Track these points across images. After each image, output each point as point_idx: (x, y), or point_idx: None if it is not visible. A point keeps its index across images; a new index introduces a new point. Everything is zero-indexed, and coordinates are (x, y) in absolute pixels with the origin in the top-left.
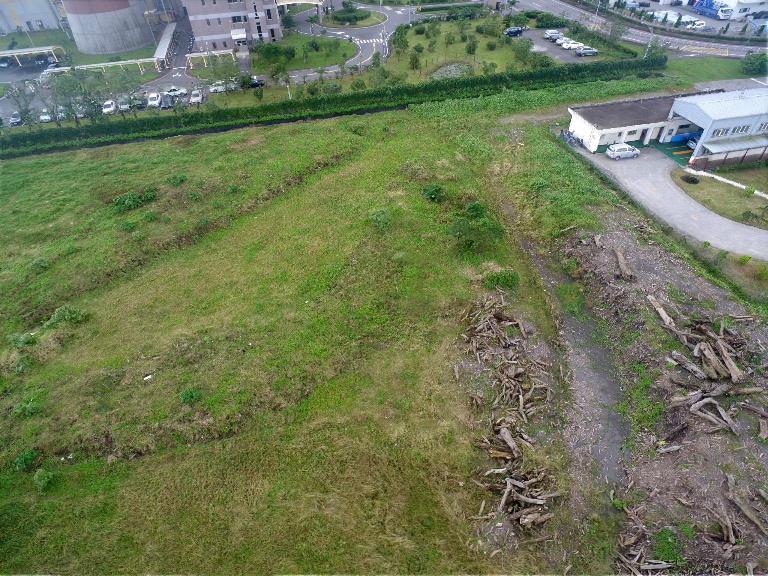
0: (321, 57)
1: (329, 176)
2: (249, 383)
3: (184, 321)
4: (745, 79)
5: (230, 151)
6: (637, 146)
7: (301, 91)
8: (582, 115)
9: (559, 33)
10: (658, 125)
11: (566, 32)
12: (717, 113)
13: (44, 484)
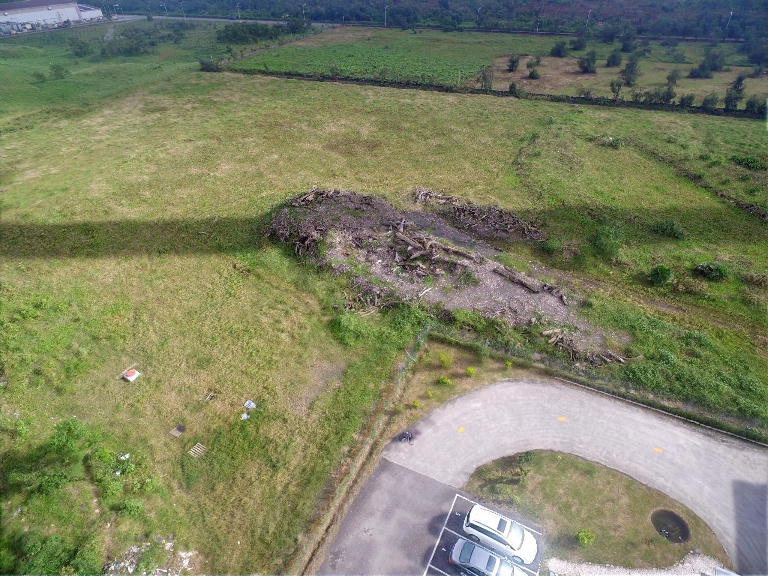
0: None
1: None
2: None
3: (595, 164)
4: None
5: None
6: None
7: None
8: None
9: None
10: None
11: None
12: None
13: (522, 137)
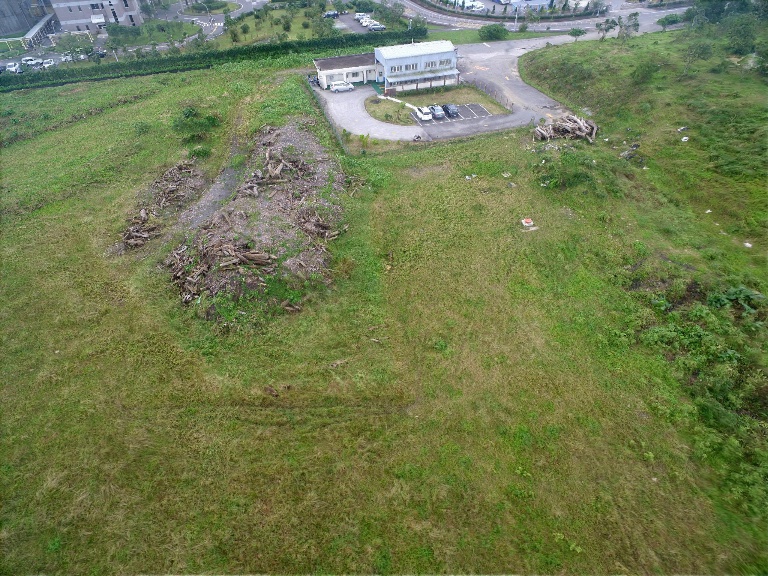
0: None
1: (124, 109)
2: (4, 203)
3: None
4: (478, 43)
5: (56, 96)
6: (359, 85)
7: (128, 56)
8: (319, 64)
9: (366, 15)
10: (367, 68)
11: (374, 15)
12: (390, 55)
13: None
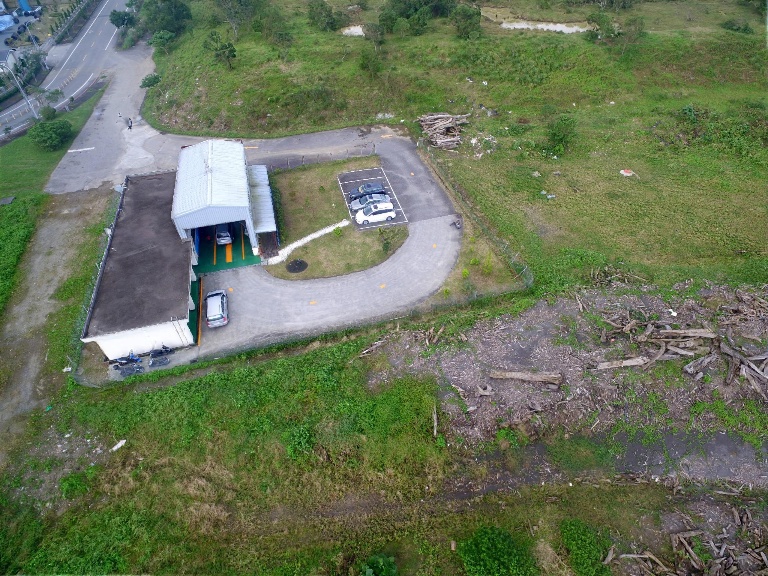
0: None
1: None
2: None
3: None
4: (66, 155)
5: None
6: (195, 289)
7: None
8: (117, 327)
9: None
10: None
11: None
12: (236, 199)
13: None
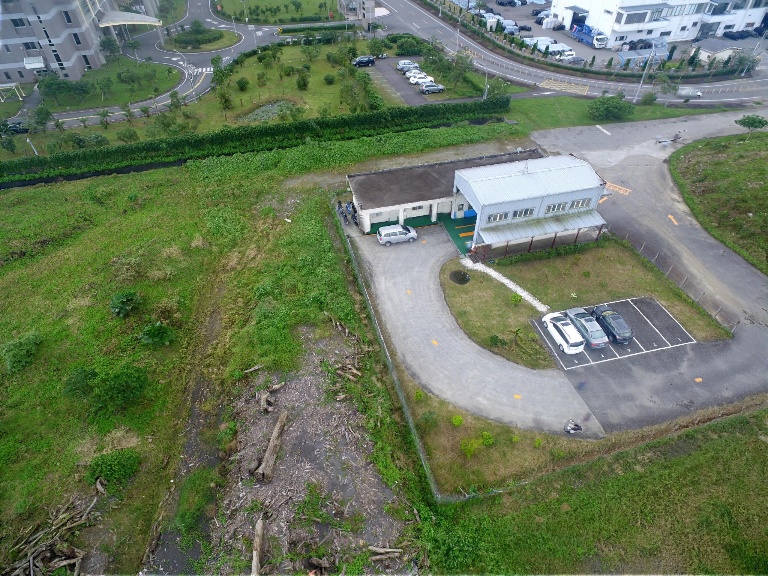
0: (129, 92)
1: (16, 272)
2: None
3: None
4: (590, 126)
5: None
6: (423, 223)
7: (55, 144)
8: (357, 186)
9: (413, 64)
10: (440, 201)
11: (423, 62)
12: (489, 195)
13: None
